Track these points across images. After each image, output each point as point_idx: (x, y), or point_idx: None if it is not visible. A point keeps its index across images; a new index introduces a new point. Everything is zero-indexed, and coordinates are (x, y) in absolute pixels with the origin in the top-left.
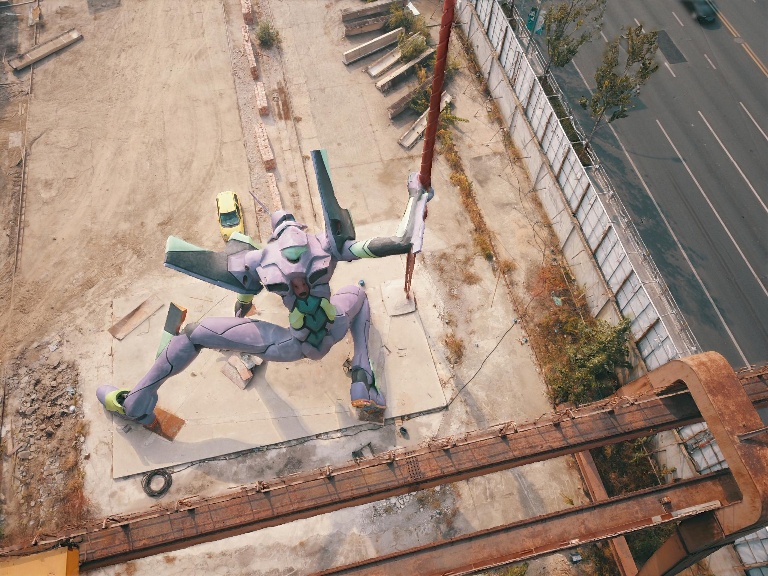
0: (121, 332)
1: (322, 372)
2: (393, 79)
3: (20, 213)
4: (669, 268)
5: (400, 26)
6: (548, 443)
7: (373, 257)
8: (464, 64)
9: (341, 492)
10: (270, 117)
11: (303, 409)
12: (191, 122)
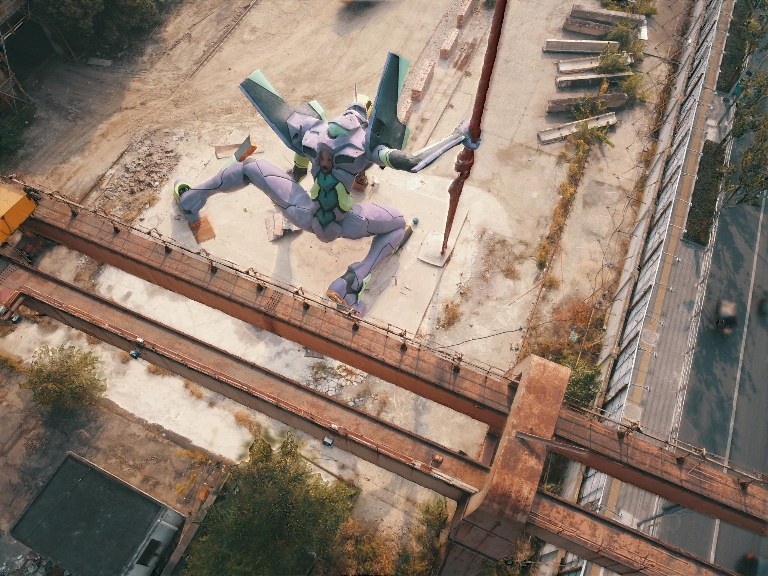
0: (222, 153)
1: (334, 265)
2: (574, 80)
3: (222, 40)
4: (710, 377)
5: (617, 40)
6: (384, 356)
7: (390, 166)
8: (654, 100)
9: (212, 284)
10: (447, 61)
11: (299, 281)
12: (384, 36)
